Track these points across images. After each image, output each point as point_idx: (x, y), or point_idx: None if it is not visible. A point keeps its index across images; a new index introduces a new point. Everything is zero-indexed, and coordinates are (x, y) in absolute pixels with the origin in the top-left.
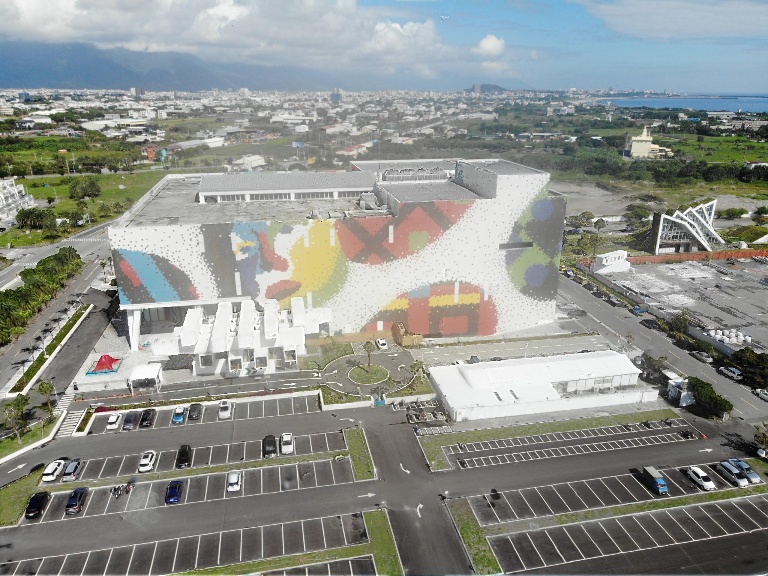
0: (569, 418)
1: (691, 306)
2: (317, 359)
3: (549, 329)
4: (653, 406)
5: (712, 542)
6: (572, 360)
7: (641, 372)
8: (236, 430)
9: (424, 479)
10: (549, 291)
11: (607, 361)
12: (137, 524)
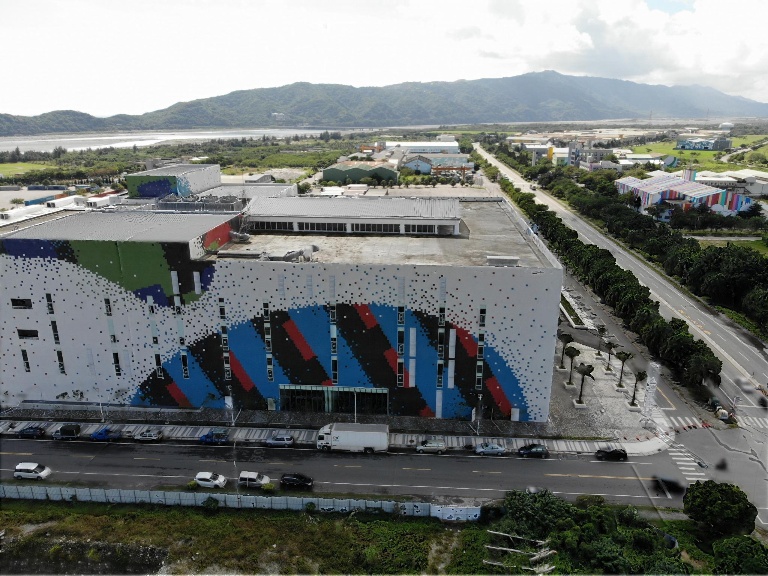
0: None
1: None
2: None
3: None
4: None
5: None
6: None
7: None
8: None
9: None
10: None
11: None
12: None
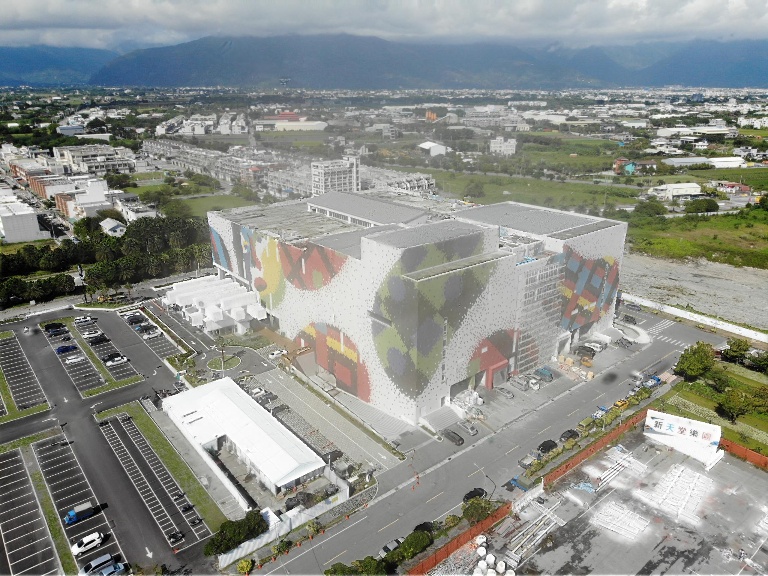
0: (188, 462)
1: (610, 538)
2: (236, 340)
3: (395, 427)
4: (234, 512)
5: (2, 554)
6: (266, 434)
7: (277, 485)
8: (133, 346)
9: (84, 414)
10: (409, 386)
11: (279, 455)
12: (41, 351)
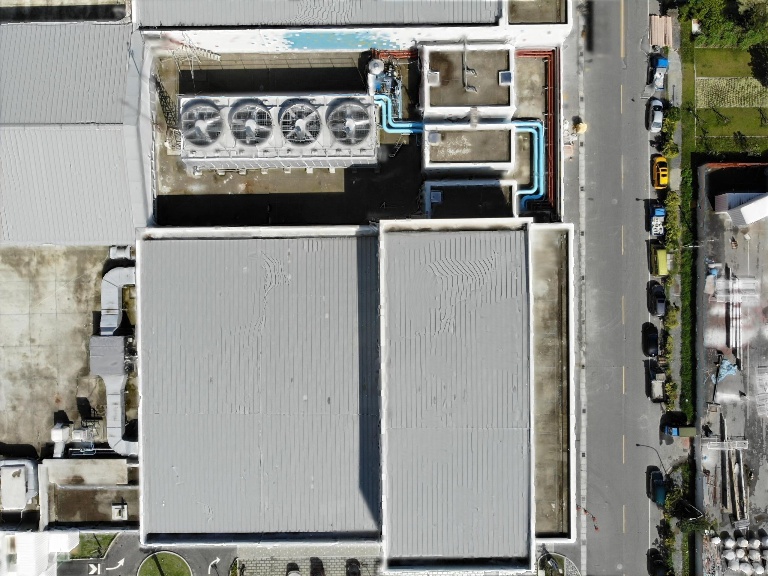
0: None
1: None
2: None
3: None
4: None
5: None
6: None
7: None
8: None
9: None
10: None
11: None
12: None
